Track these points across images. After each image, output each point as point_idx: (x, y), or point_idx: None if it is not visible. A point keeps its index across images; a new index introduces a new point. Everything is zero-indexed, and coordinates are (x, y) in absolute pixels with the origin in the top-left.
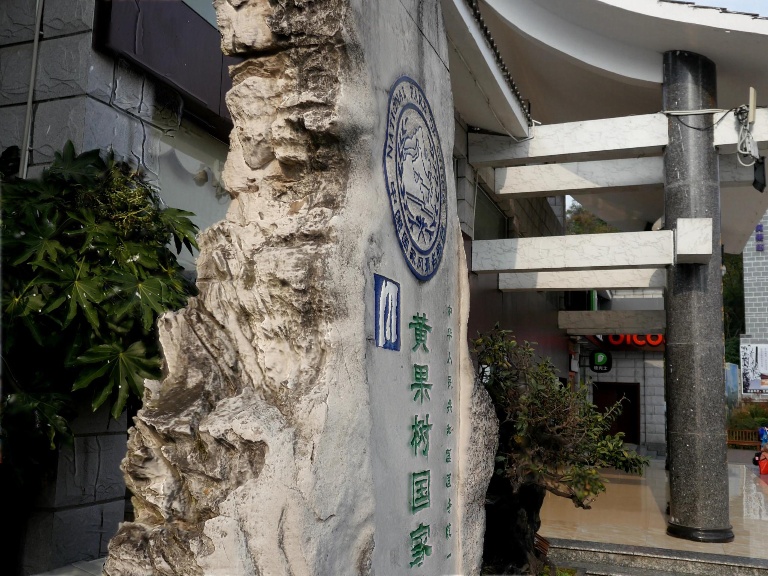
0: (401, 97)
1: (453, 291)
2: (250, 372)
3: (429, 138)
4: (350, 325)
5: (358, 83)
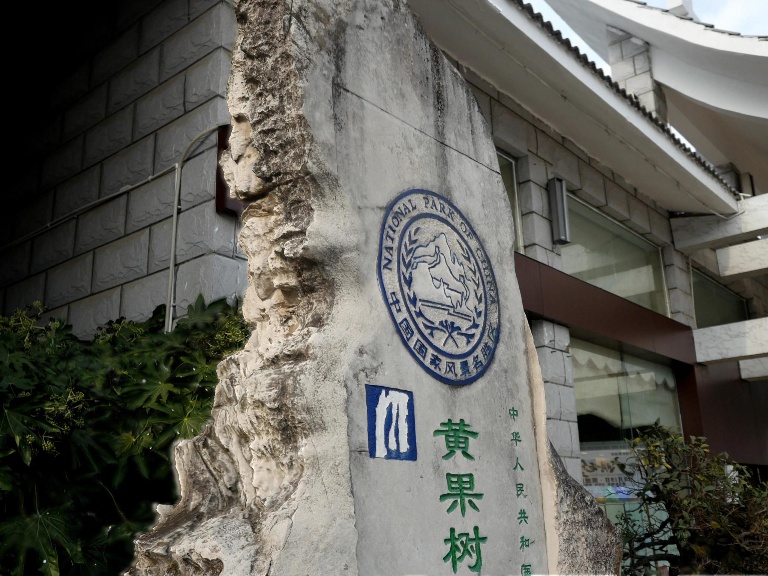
0: (407, 209)
1: (519, 392)
2: (246, 492)
3: (460, 242)
4: (329, 438)
5: (334, 206)
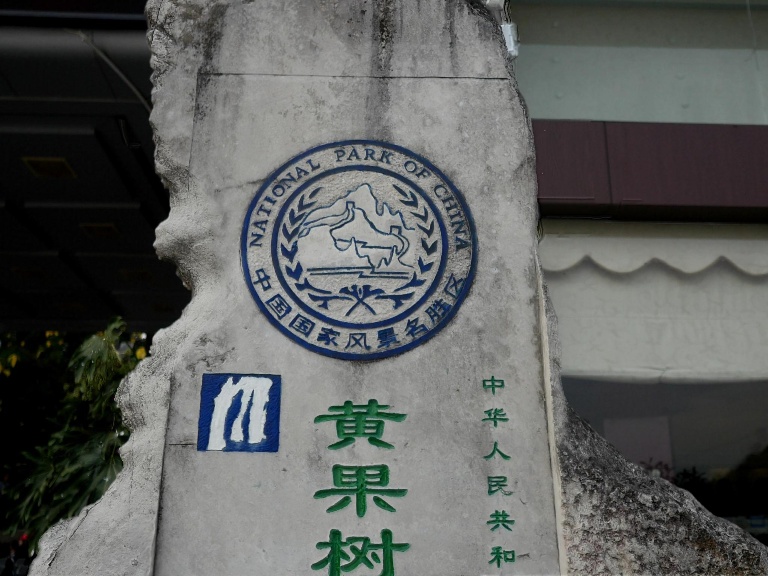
0: (303, 172)
1: (511, 356)
2: None
3: (399, 187)
4: (147, 433)
5: (187, 198)
